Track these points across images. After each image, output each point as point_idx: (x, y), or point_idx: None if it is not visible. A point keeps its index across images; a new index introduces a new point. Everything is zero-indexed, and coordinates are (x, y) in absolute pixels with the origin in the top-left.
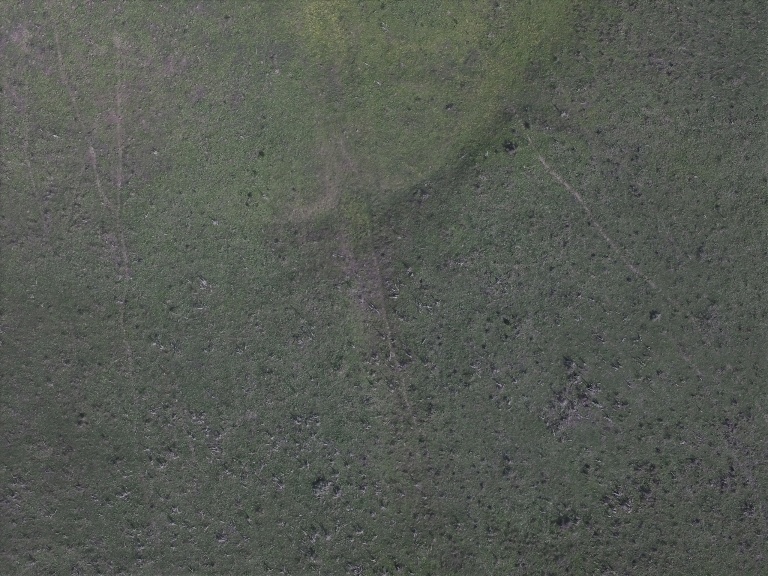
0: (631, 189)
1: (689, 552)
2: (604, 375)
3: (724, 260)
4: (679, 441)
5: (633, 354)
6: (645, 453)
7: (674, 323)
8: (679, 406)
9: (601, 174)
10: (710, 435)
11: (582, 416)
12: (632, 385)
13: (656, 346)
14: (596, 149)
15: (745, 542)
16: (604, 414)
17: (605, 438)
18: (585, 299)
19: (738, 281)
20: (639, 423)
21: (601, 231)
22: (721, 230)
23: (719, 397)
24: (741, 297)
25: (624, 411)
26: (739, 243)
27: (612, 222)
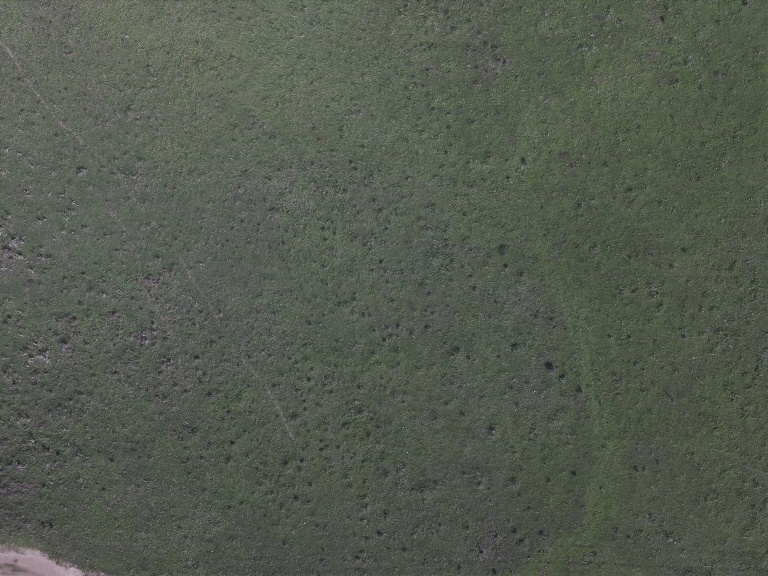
0: (61, 46)
1: (104, 402)
2: (31, 228)
3: (152, 118)
4: (101, 294)
5: (59, 208)
6: (67, 305)
7: (101, 179)
8: (103, 260)
9: (33, 31)
10: (133, 289)
11: (6, 268)
12: (57, 238)
13: (82, 201)
14: (29, 6)
15: (162, 394)
16: (29, 266)
17: (29, 290)
18: (13, 153)
19: (166, 139)
20: (63, 276)
21: (31, 87)
22: (151, 89)
23: (143, 252)
24: (169, 155)
25: (48, 264)
26: (168, 102)
27: (42, 78)
